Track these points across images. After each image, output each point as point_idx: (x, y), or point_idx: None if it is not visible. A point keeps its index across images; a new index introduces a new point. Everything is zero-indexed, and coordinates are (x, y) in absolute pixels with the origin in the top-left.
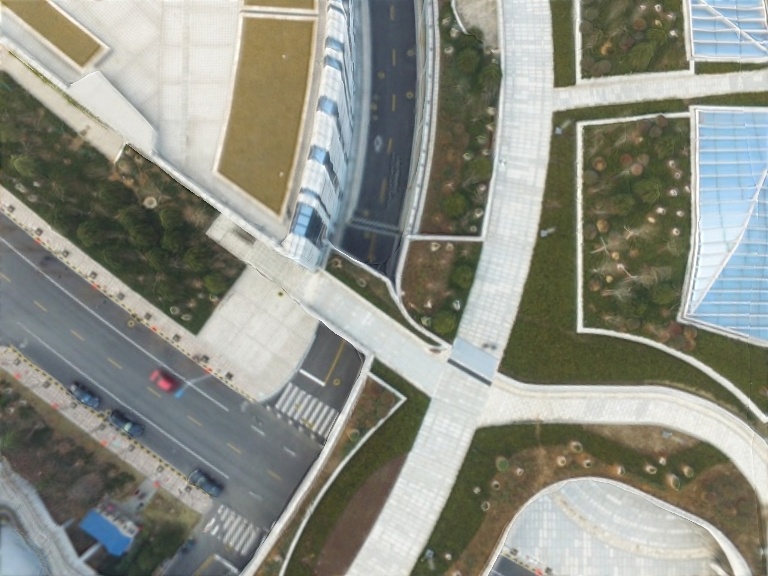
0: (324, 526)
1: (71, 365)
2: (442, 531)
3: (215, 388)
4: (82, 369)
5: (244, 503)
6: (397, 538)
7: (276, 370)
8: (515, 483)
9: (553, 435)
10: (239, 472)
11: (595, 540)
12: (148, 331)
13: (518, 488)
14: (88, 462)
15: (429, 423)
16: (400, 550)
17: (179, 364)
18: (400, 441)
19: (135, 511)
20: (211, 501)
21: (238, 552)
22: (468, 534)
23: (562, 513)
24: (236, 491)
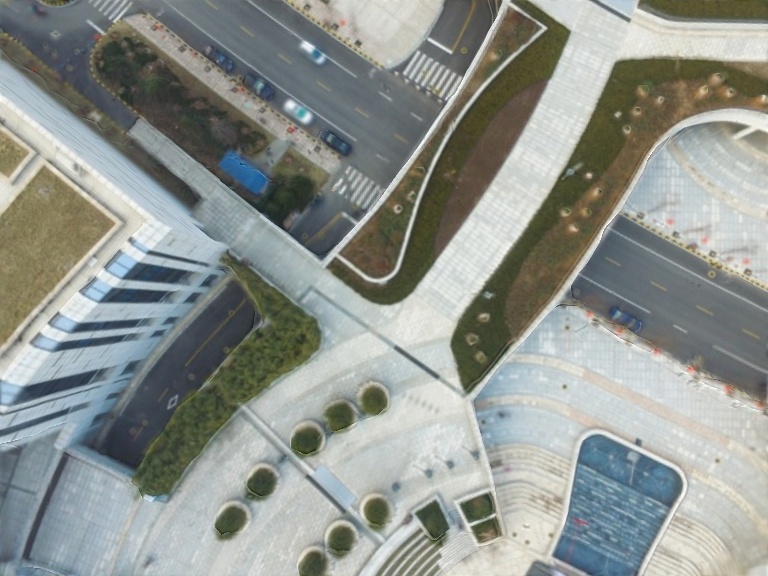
0: (466, 143)
1: (205, 33)
2: (582, 152)
3: (344, 55)
4: (215, 37)
5: (371, 165)
6: (537, 159)
7: (404, 39)
8: (655, 112)
9: (694, 68)
10: (367, 135)
11: (724, 206)
12: (279, 2)
13: (658, 117)
14: (222, 118)
15: (568, 54)
16: (540, 170)
17: (309, 33)
18: (541, 66)
19: (266, 167)
20: (339, 162)
21: (365, 211)
22: (608, 157)
23: (690, 179)
24: (364, 153)
